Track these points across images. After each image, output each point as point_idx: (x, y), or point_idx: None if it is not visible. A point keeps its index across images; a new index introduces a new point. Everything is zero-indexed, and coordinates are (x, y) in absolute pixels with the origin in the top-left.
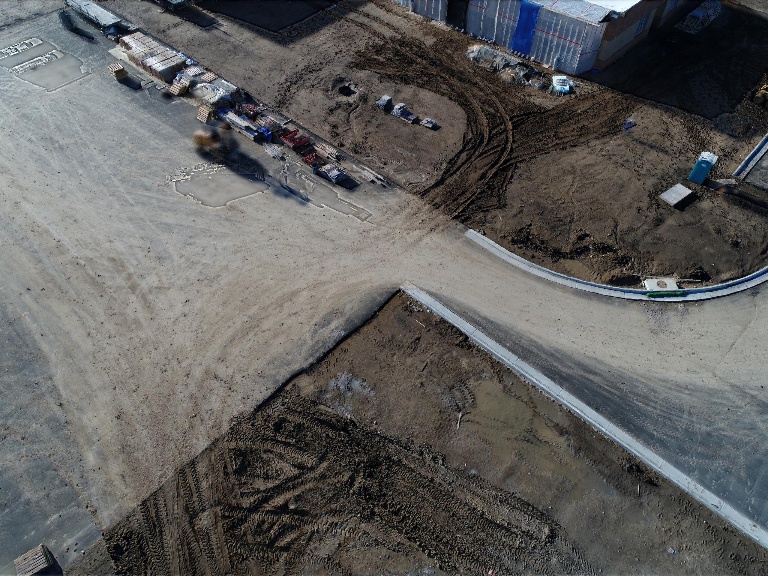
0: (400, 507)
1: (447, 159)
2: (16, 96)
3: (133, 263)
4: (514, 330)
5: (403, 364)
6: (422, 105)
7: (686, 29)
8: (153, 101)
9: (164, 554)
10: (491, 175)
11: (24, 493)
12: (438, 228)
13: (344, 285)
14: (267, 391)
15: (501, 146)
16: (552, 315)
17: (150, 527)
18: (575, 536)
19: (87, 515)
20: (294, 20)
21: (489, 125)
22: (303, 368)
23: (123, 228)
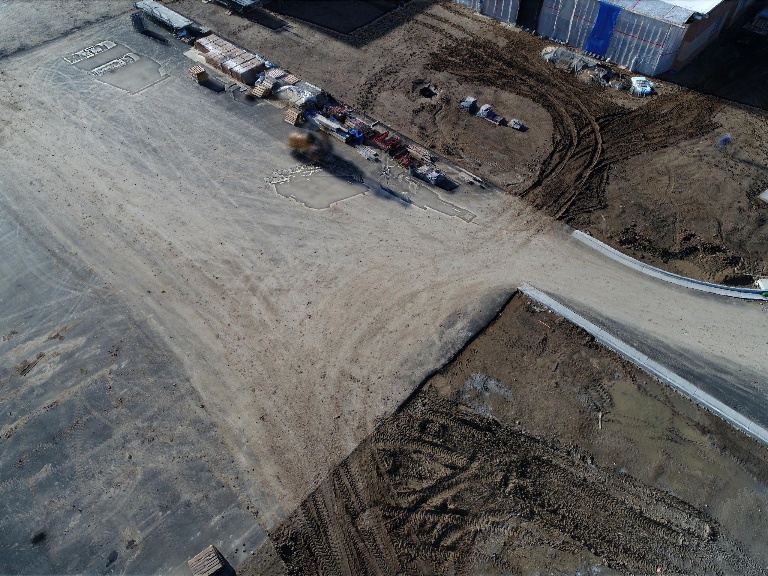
0: (558, 506)
1: (540, 160)
2: (100, 99)
3: (248, 265)
4: (638, 330)
5: (534, 364)
6: (506, 106)
7: (755, 30)
8: (237, 103)
9: (332, 554)
10: (587, 176)
11: (183, 494)
12: (544, 229)
13: (462, 286)
14: (405, 392)
15: (592, 147)
16: (673, 315)
17: (314, 527)
18: (736, 534)
19: (250, 516)
20: (363, 22)
21: (576, 126)
22: (437, 369)
23: (232, 230)
